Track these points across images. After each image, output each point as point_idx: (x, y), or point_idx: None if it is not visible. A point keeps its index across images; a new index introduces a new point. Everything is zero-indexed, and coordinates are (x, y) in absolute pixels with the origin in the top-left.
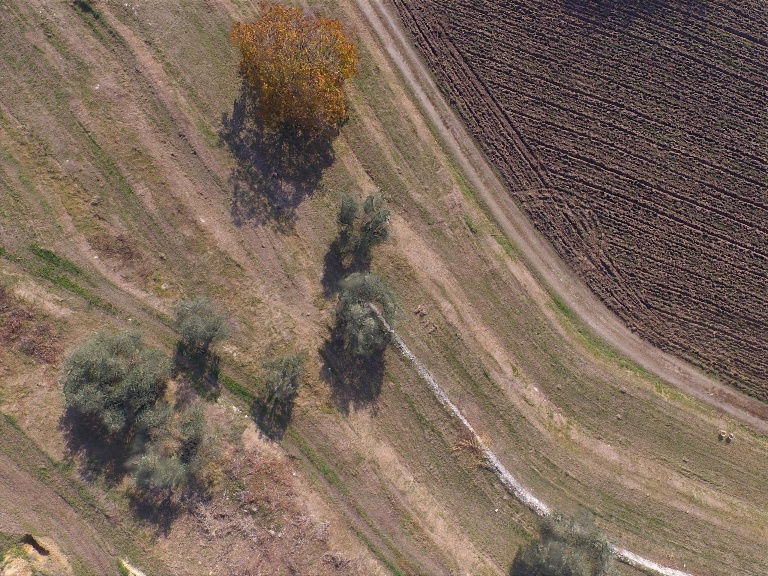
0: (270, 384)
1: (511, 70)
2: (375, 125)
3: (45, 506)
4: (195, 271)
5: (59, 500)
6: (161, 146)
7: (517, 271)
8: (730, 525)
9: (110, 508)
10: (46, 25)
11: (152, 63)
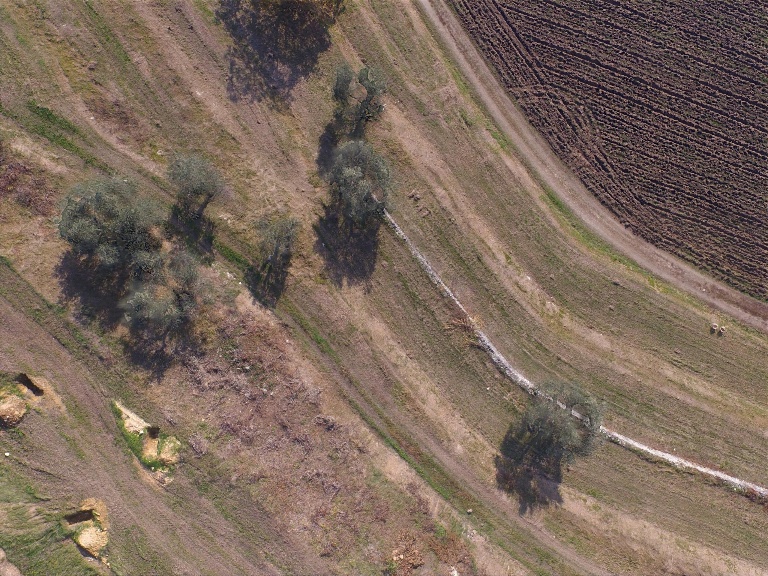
0: (264, 252)
1: None
2: (371, 16)
3: (40, 347)
4: (190, 139)
5: (54, 342)
6: (158, 20)
7: (511, 164)
8: (720, 412)
9: (104, 351)
10: None
11: None
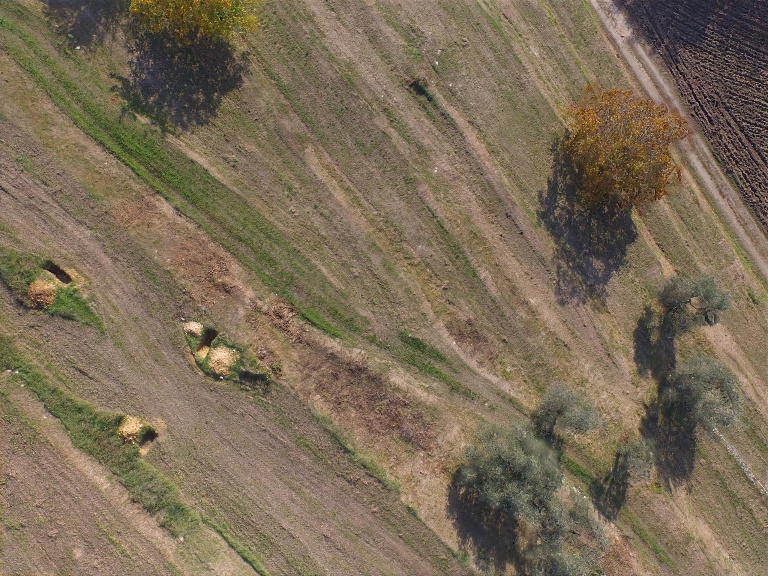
0: (607, 465)
1: None
2: None
3: None
4: (534, 353)
5: None
6: (491, 227)
7: None
8: None
9: None
10: (388, 109)
11: (478, 144)
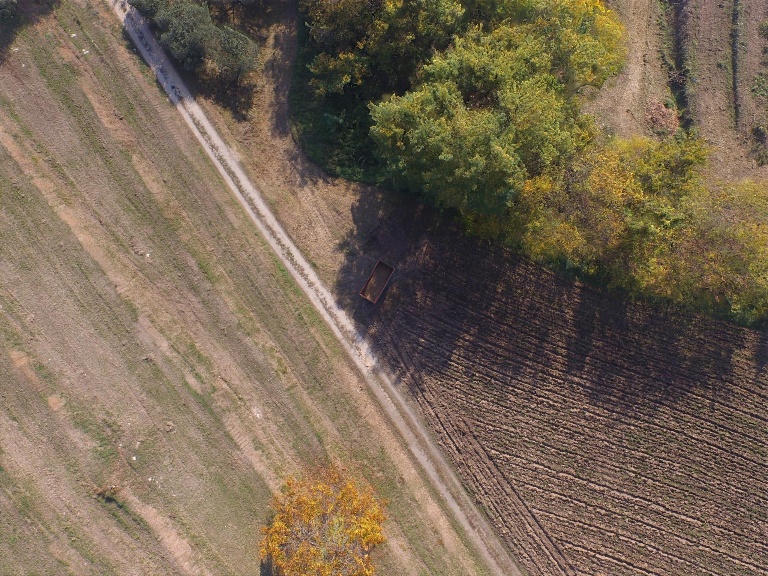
0: None
1: (537, 467)
2: (401, 544)
3: None
4: None
5: None
6: None
7: None
8: None
9: None
10: (70, 528)
11: (177, 543)
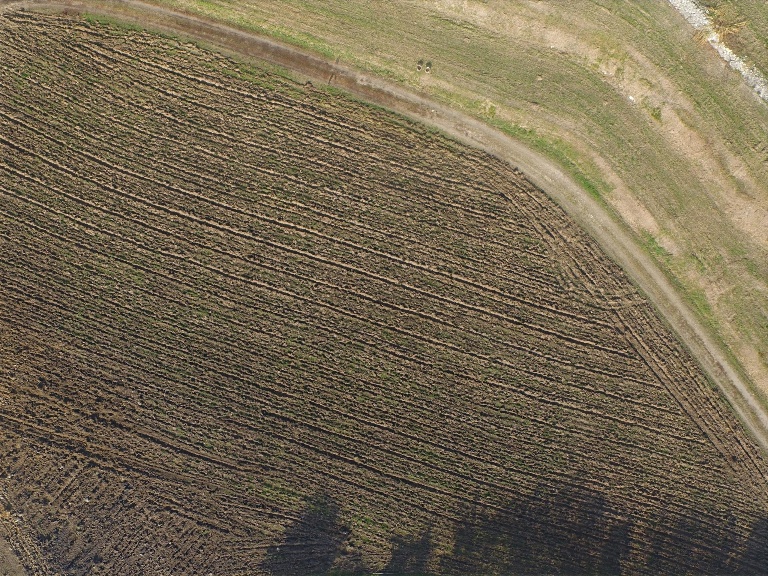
0: None
1: (658, 428)
2: None
3: None
4: None
5: None
6: None
7: (645, 220)
8: None
9: None
10: None
11: None
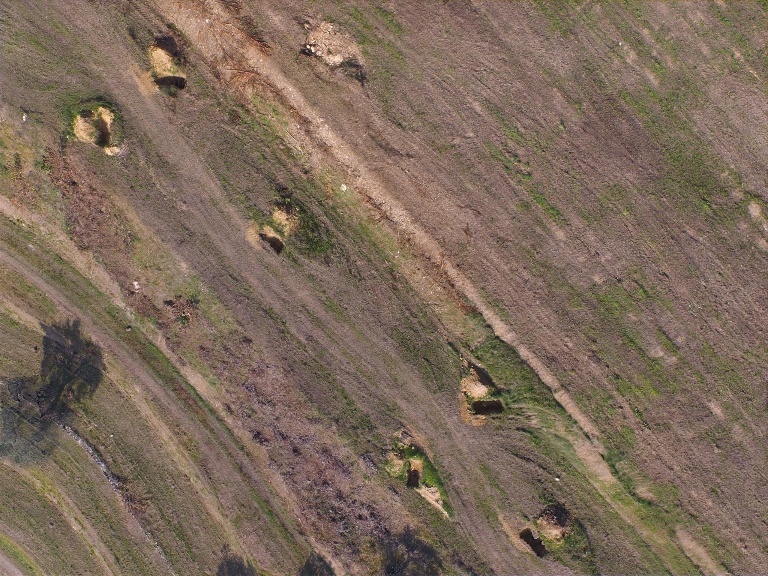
0: None
1: None
2: None
3: None
4: None
5: None
6: None
7: None
8: None
9: None
10: None
11: None
